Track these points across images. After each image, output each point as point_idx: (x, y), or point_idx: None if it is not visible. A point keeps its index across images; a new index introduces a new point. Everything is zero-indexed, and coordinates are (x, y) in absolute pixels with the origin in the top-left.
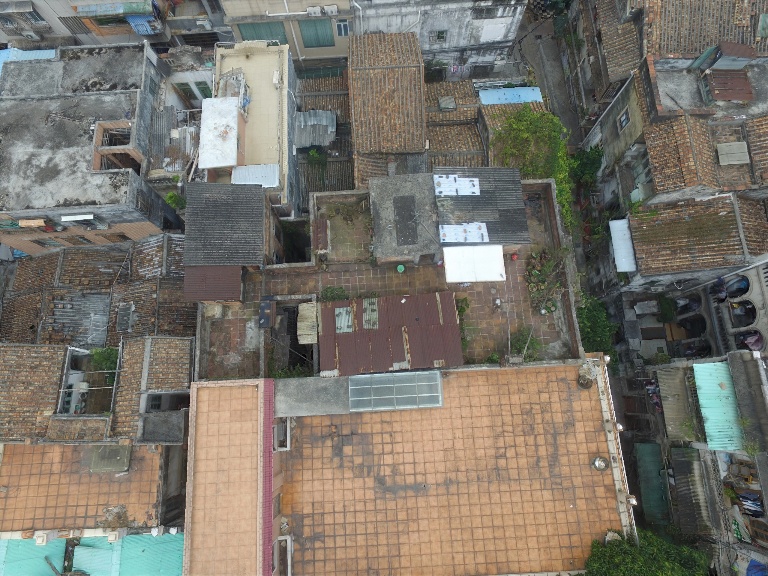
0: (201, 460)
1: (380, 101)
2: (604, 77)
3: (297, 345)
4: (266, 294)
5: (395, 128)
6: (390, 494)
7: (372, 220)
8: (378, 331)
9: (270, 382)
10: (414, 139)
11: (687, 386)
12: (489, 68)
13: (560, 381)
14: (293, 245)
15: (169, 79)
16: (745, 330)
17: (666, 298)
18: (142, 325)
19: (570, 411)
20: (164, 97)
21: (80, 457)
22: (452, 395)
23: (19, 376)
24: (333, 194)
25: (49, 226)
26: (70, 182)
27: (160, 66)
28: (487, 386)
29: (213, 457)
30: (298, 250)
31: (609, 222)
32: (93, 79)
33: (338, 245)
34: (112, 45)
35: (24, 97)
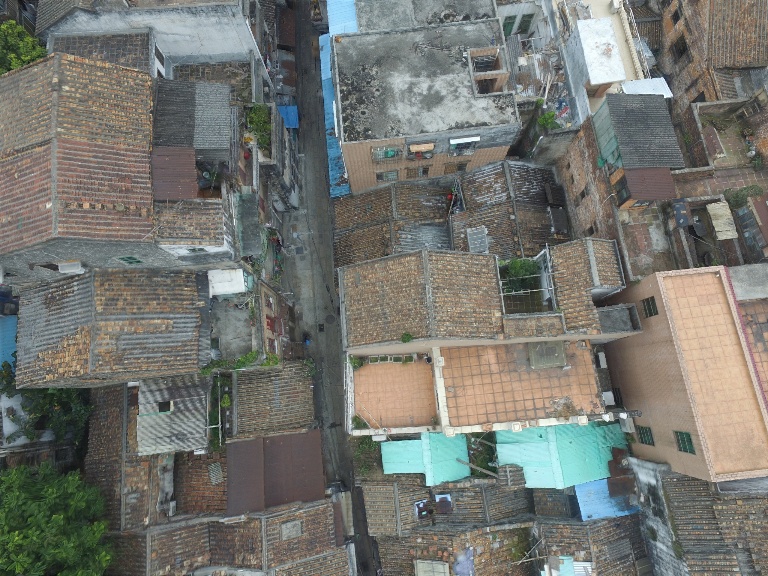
0: (683, 340)
1: (739, 16)
2: None
3: (701, 245)
4: (661, 200)
5: (750, 42)
6: None
7: None
8: None
9: None
10: (767, 52)
11: None
12: None
13: None
14: None
15: None
16: None
17: None
18: (501, 246)
19: None
20: None
21: (514, 357)
22: None
23: (471, 281)
24: (714, 104)
25: None
26: (456, 106)
27: None
28: None
29: (693, 337)
30: None
31: None
32: (444, 12)
33: None
34: None
35: (390, 30)
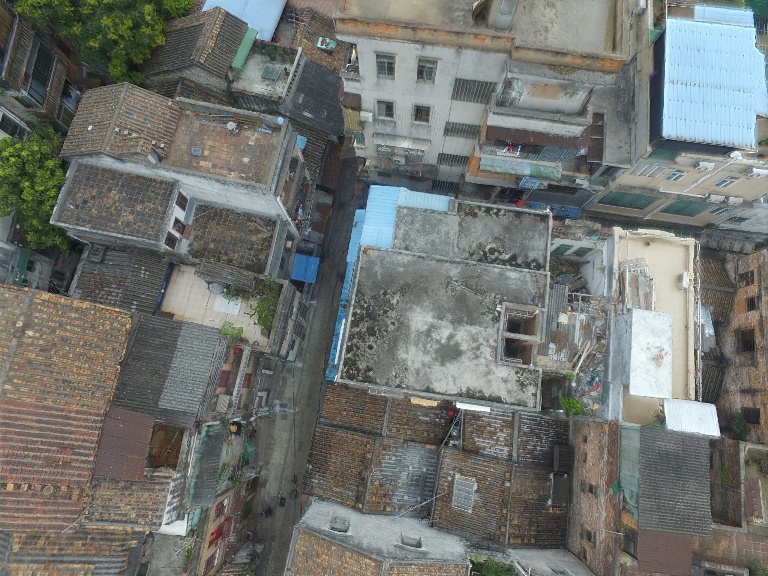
0: None
1: None
2: None
3: None
4: None
5: None
6: None
7: None
8: None
9: None
10: None
11: None
12: None
13: None
14: None
15: None
16: None
17: None
18: (487, 511)
19: None
20: None
21: None
22: None
23: None
24: (767, 449)
25: None
26: (473, 368)
27: None
28: None
29: None
30: None
31: None
32: (491, 244)
33: None
34: (514, 209)
35: (425, 256)
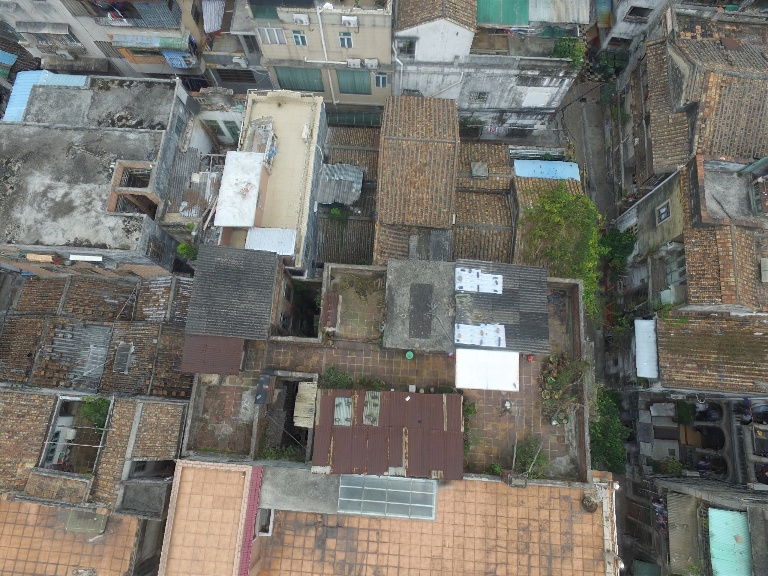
0: (177, 546)
1: (410, 173)
2: (648, 164)
3: (292, 423)
4: (267, 364)
5: (422, 202)
6: None
7: (386, 306)
8: (377, 429)
9: (258, 470)
10: (440, 216)
11: (698, 520)
12: (528, 130)
13: (563, 499)
14: (303, 300)
15: (198, 116)
16: (767, 462)
17: (685, 401)
18: (139, 369)
19: (570, 533)
20: (190, 135)
21: (57, 511)
22: (447, 498)
23: (5, 424)
24: (349, 268)
25: (57, 260)
26: (83, 221)
27: (190, 104)
28: (485, 493)
29: (190, 544)
30: (308, 301)
31: (635, 321)
32: (120, 113)
33: (348, 320)
34: (143, 79)
35: (48, 125)
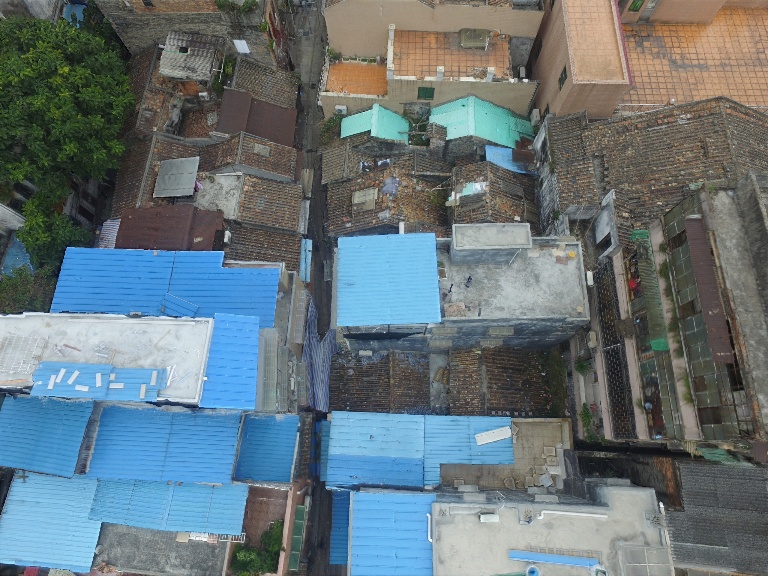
0: (570, 7)
1: None
2: None
3: None
4: None
5: None
6: (681, 69)
7: None
8: None
9: None
10: None
11: None
12: None
13: None
14: None
15: None
16: None
17: None
18: None
19: None
20: None
21: (450, 41)
22: (720, 19)
23: None
24: None
25: None
26: None
27: None
28: (746, 15)
29: (578, 6)
30: None
31: None
32: None
33: None
34: None
35: None
